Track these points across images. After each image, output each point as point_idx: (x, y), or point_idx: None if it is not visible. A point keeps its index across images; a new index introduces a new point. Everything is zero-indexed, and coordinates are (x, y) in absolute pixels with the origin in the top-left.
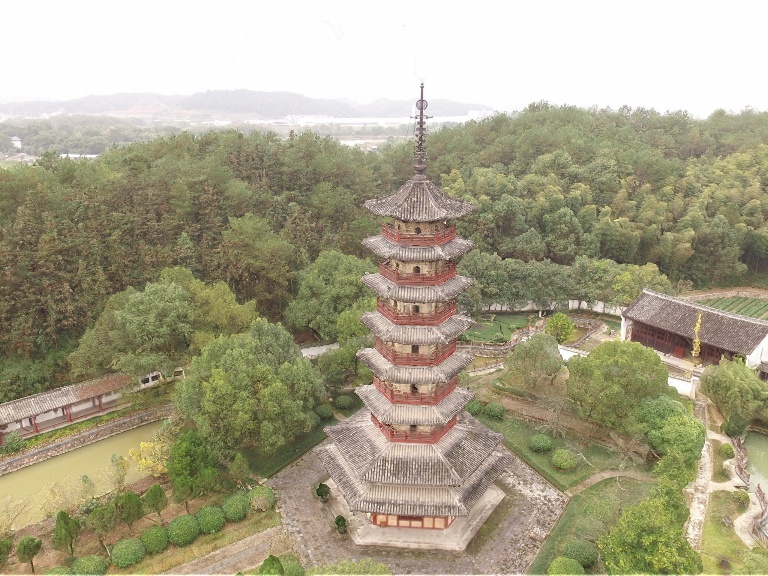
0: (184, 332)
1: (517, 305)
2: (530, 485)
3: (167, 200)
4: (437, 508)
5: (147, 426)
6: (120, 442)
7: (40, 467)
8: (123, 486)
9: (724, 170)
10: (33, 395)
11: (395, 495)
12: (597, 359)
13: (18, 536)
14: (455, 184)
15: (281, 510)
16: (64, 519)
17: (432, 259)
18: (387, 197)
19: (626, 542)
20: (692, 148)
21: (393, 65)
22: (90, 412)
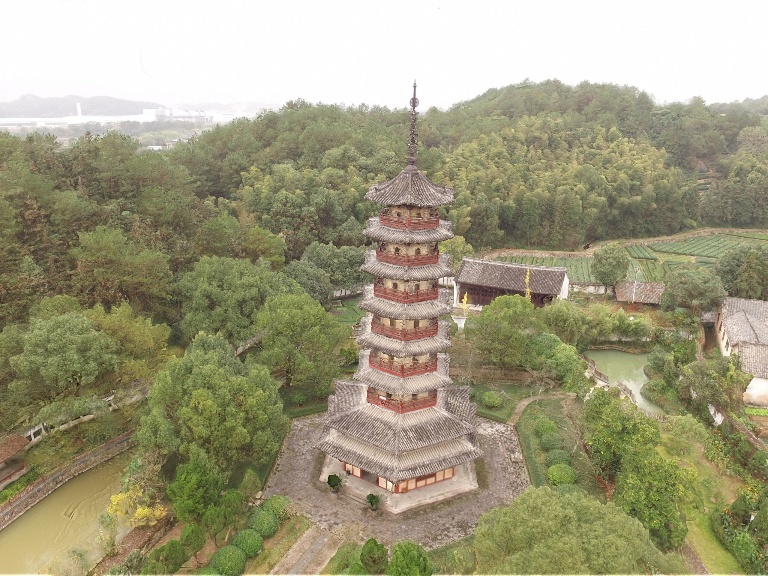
0: (113, 364)
1: (359, 288)
2: (480, 426)
3: None
4: (458, 458)
5: (62, 488)
6: (35, 515)
7: None
8: (116, 548)
9: (464, 157)
10: None
11: (420, 458)
12: (494, 313)
13: None
14: (264, 181)
15: None
16: None
17: (442, 239)
18: (385, 188)
19: (614, 432)
20: (425, 140)
21: (114, 59)
22: None
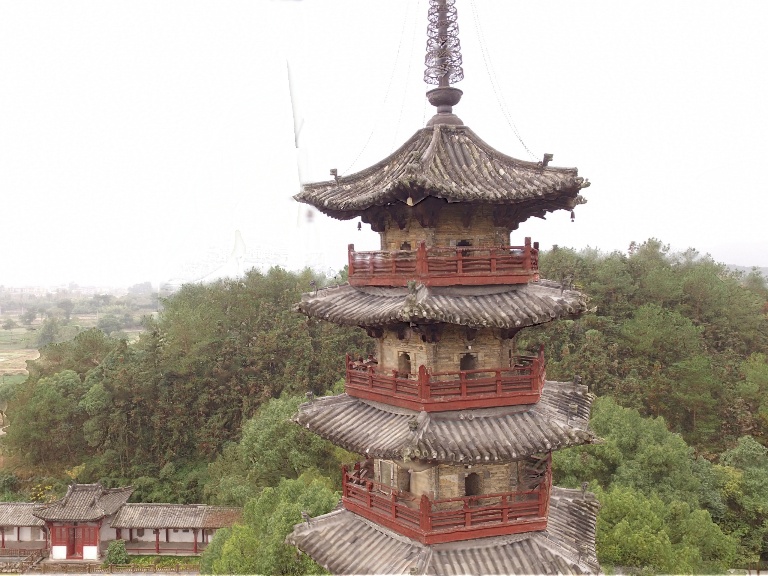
0: (294, 464)
1: None
2: None
3: None
4: None
5: None
6: None
7: None
8: None
9: None
10: (167, 503)
11: None
12: None
13: None
14: None
15: None
16: None
17: (378, 317)
18: None
19: None
20: None
21: None
22: None
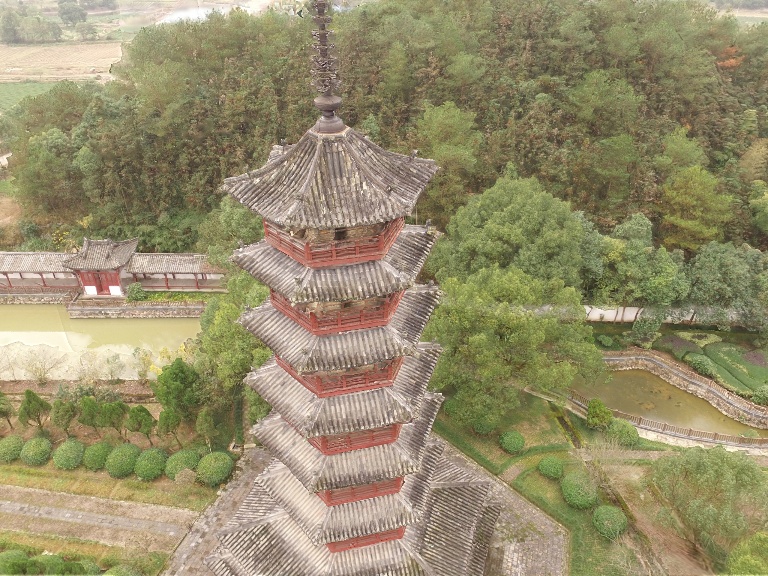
0: None
1: None
2: None
3: (387, 68)
4: None
5: None
6: None
7: (150, 322)
8: (144, 380)
9: None
10: (169, 253)
11: None
12: None
13: (47, 385)
14: None
15: (222, 494)
16: (29, 397)
17: (280, 291)
18: None
19: None
20: None
21: None
22: (217, 285)
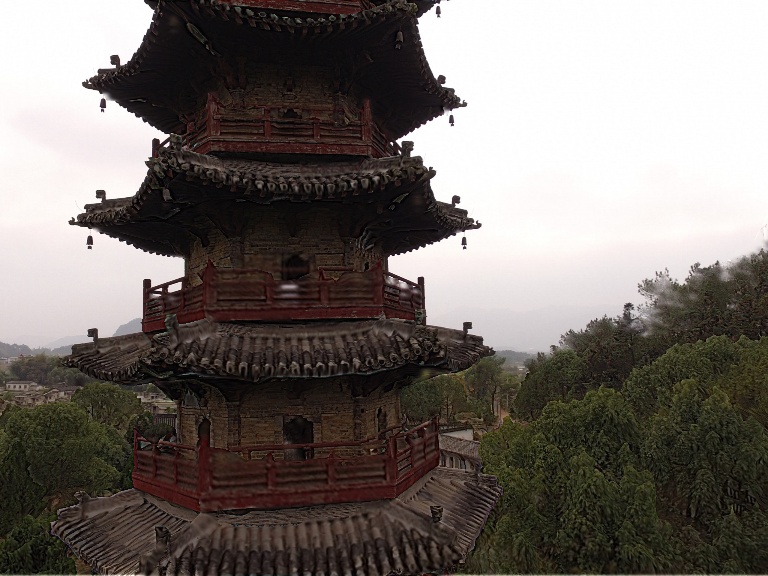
0: None
1: None
2: None
3: None
4: None
5: None
6: None
7: None
8: None
9: None
10: None
11: None
12: None
13: None
14: None
15: None
16: None
17: None
18: None
19: None
20: None
21: None
22: None
